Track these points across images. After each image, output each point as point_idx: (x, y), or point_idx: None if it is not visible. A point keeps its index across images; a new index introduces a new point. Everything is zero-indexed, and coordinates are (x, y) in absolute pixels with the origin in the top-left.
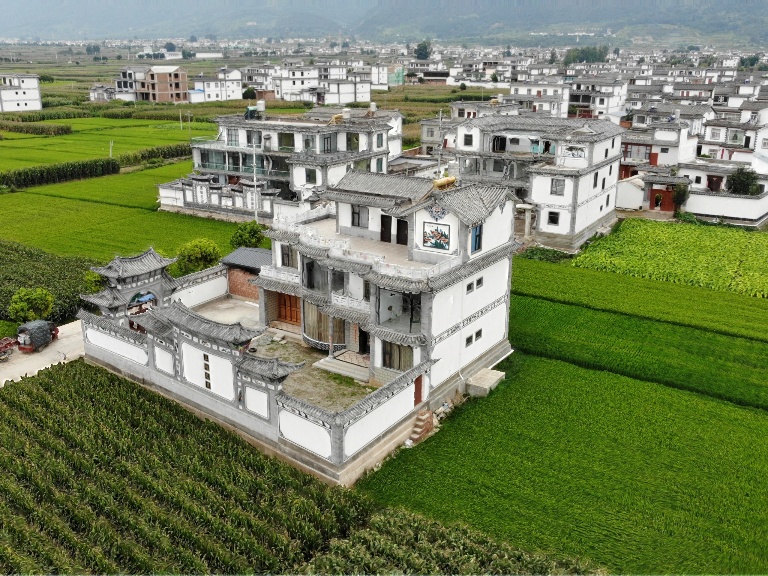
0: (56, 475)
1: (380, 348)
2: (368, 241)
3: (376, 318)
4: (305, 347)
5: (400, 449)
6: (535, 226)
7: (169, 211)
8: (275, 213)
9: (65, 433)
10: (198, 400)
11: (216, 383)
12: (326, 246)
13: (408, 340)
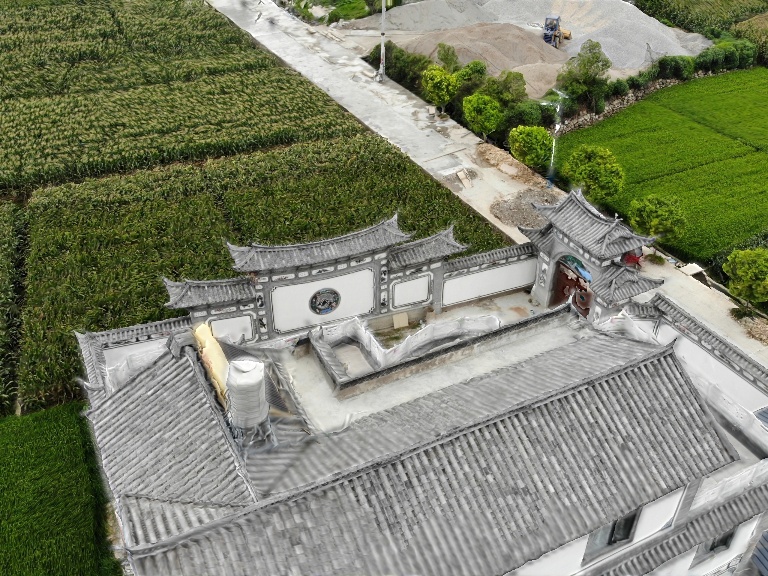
0: None
1: None
2: None
3: None
4: None
5: None
6: None
7: None
8: None
9: None
10: None
11: None
12: (418, 342)
13: None
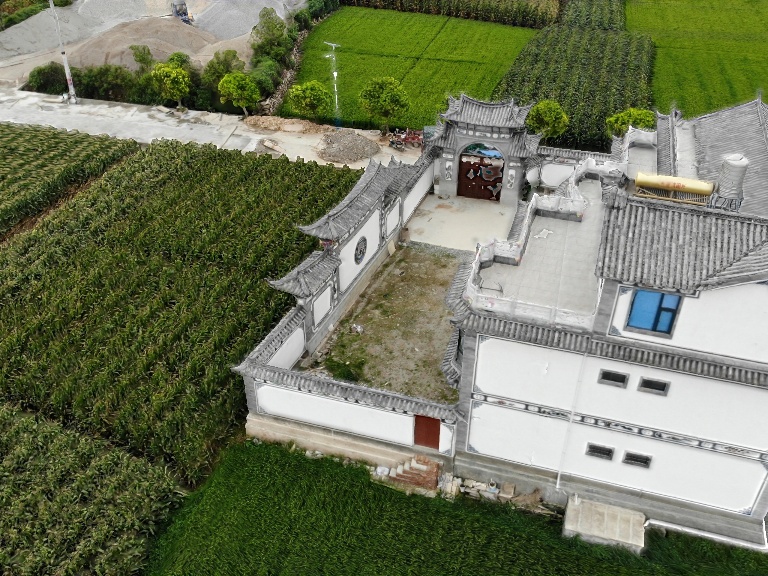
0: None
1: None
2: None
3: None
4: None
5: (363, 466)
6: None
7: None
8: None
9: None
10: None
11: None
12: None
13: (445, 366)
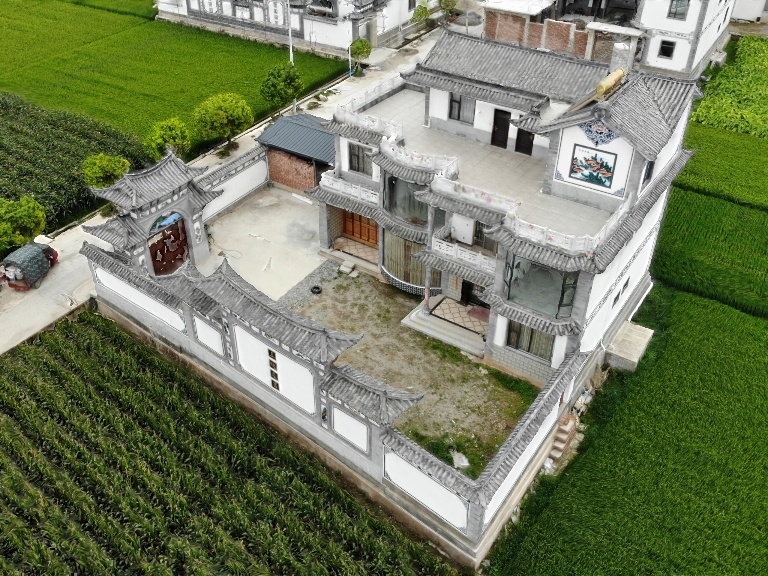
0: (88, 564)
1: (505, 324)
2: (473, 145)
3: (503, 288)
4: (384, 284)
5: (539, 476)
6: (640, 58)
7: (170, 21)
8: (306, 31)
9: (90, 474)
10: (261, 396)
11: (287, 387)
12: (422, 165)
13: (554, 330)
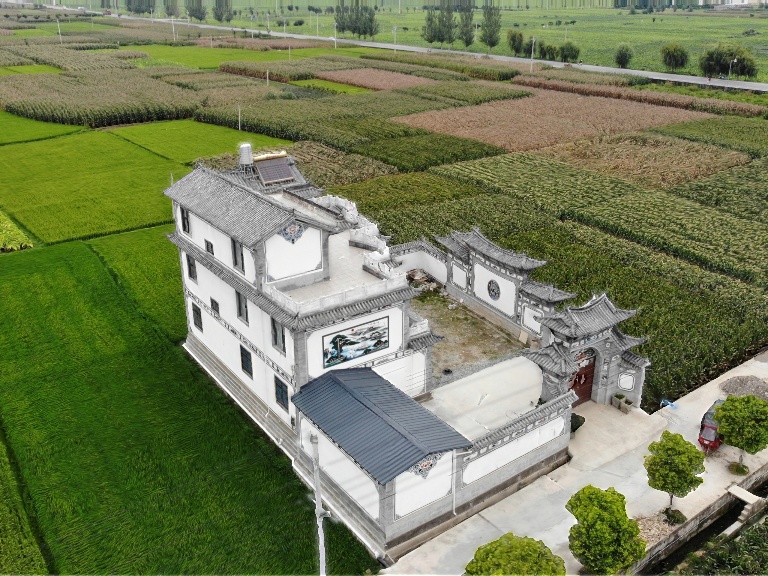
0: None
1: None
2: None
3: None
4: None
5: None
6: None
7: None
8: None
9: None
10: None
11: None
12: (371, 243)
13: None
